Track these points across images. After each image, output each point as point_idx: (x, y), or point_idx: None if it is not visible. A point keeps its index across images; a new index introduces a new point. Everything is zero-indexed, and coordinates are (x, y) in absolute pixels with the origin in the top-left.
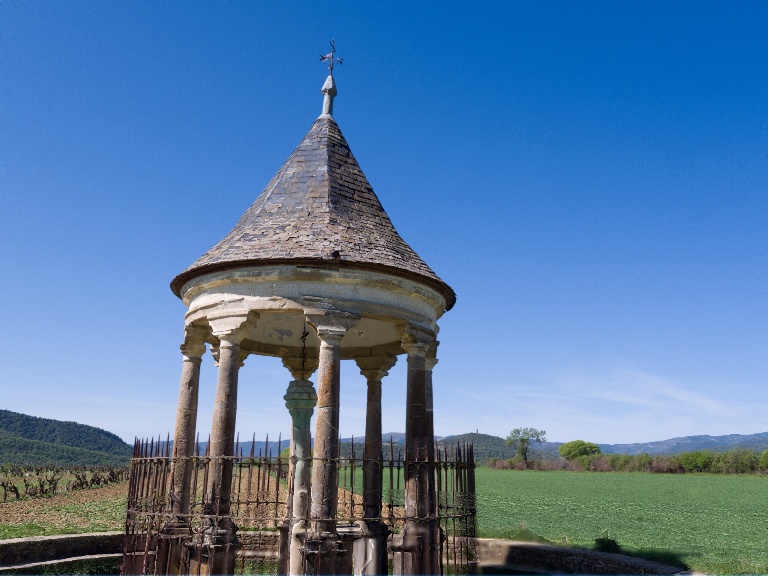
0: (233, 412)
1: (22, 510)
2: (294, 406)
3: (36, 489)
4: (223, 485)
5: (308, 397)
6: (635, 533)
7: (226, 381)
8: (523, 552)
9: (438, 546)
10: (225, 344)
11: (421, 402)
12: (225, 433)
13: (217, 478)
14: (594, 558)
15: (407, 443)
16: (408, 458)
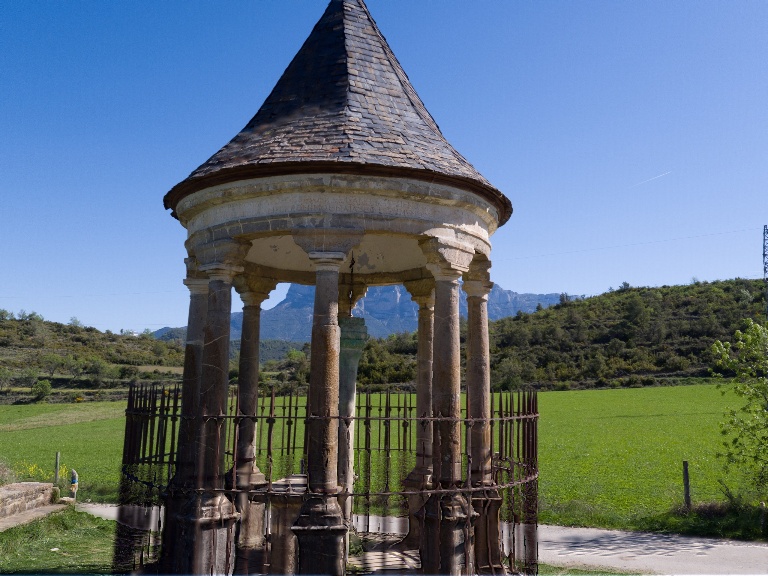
0: None
1: None
2: None
3: None
4: None
5: None
6: None
7: None
8: None
9: None
10: None
11: None
12: None
13: None
14: None
15: None
16: None
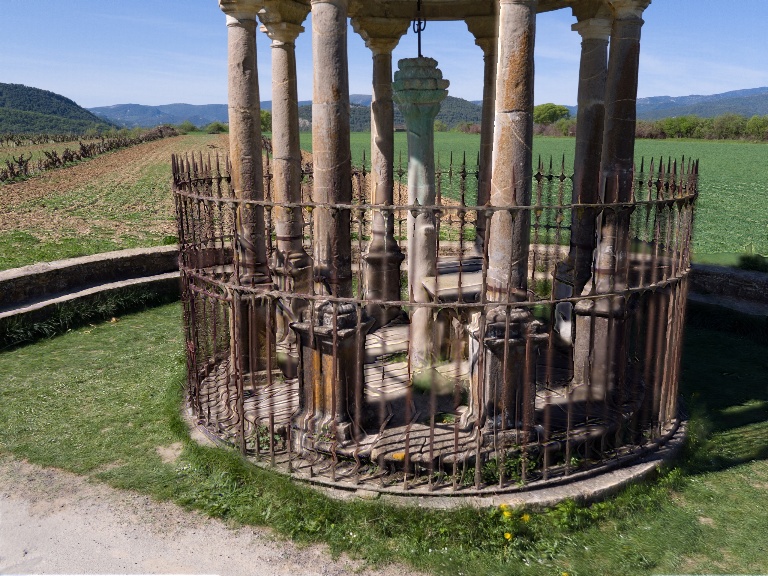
0: (346, 119)
1: (0, 207)
2: (412, 100)
3: (6, 173)
4: (342, 238)
5: (434, 86)
6: (721, 227)
7: (331, 65)
8: (639, 266)
9: (669, 318)
10: None
11: (634, 96)
12: (338, 156)
13: (332, 229)
14: (745, 279)
15: (606, 161)
16: (607, 184)
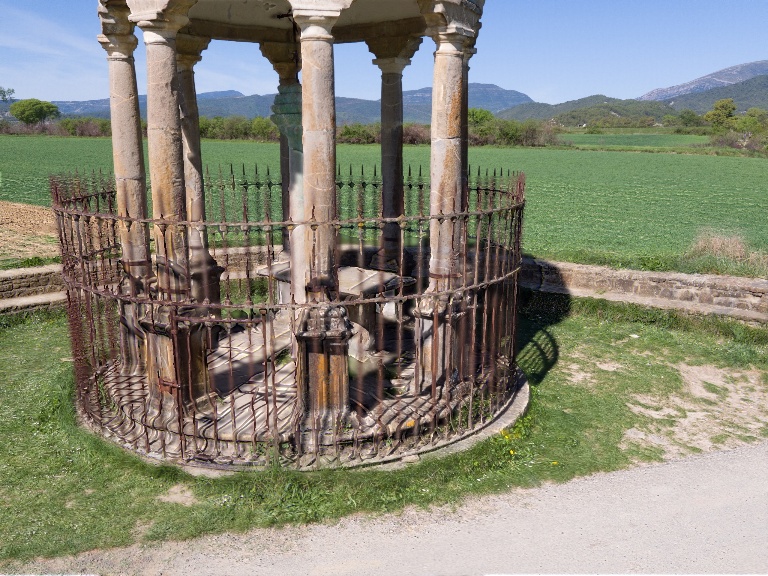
0: None
1: None
2: None
3: None
4: None
5: None
6: None
7: (329, 96)
8: (355, 255)
9: None
10: (321, 33)
11: None
12: None
13: (332, 242)
14: None
15: None
16: None
